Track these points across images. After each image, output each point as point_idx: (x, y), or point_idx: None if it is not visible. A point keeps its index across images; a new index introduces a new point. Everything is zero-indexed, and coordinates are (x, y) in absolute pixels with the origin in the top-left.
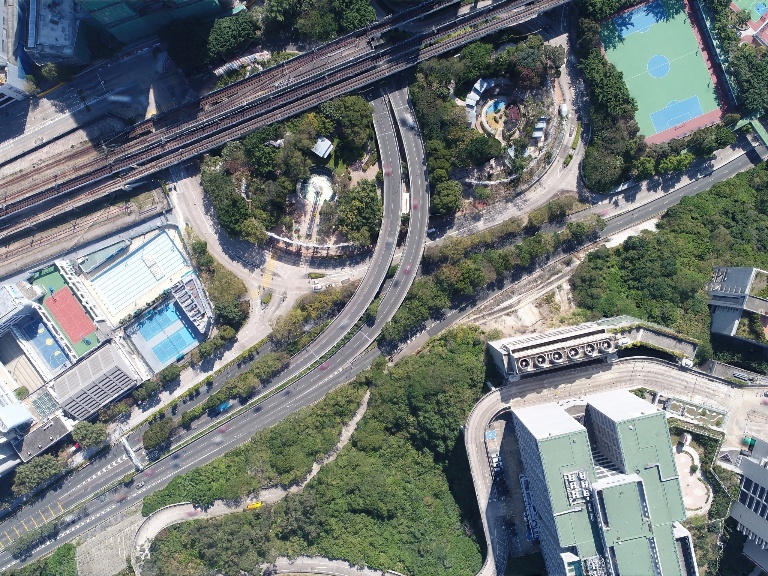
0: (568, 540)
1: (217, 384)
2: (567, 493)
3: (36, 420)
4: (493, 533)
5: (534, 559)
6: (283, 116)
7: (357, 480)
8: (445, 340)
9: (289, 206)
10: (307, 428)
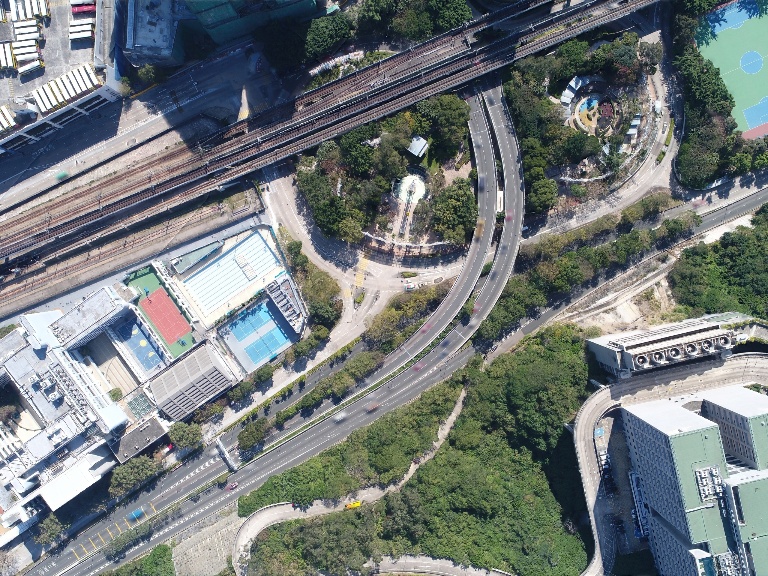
0: (700, 536)
1: (310, 384)
2: (699, 489)
3: (131, 421)
4: (601, 531)
5: (643, 556)
6: (378, 115)
7: (458, 479)
8: (541, 338)
9: (383, 205)
10: (404, 427)
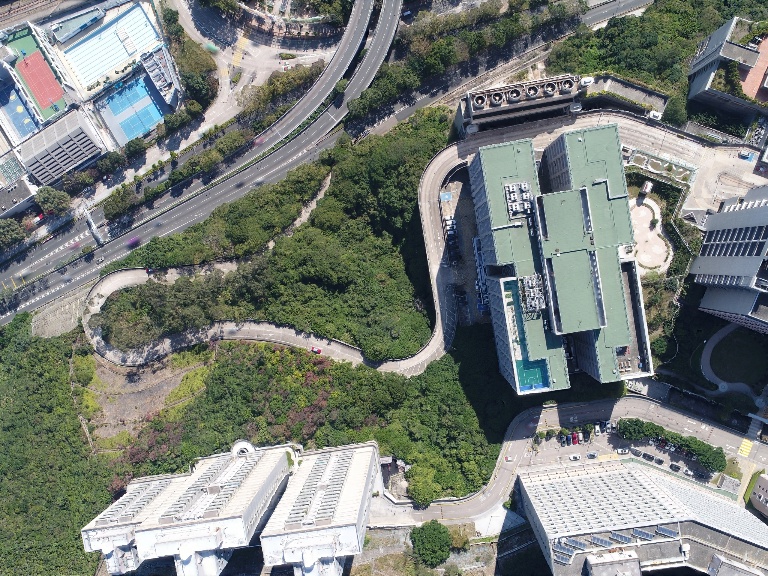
0: (506, 257)
1: (182, 164)
2: (507, 206)
3: (2, 185)
4: (443, 301)
5: (483, 327)
6: None
7: None
8: None
9: None
10: (266, 204)
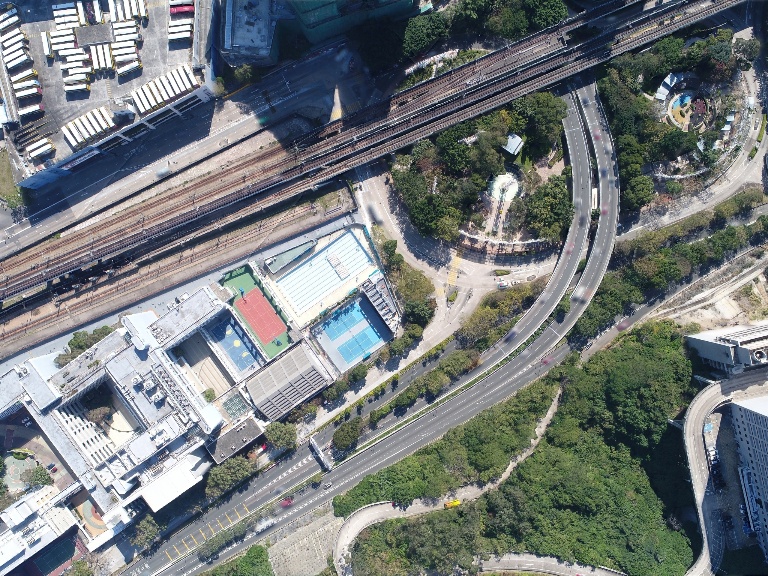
0: None
1: (402, 383)
2: None
3: (226, 422)
4: (709, 526)
5: (753, 552)
6: (474, 114)
7: (559, 476)
8: (636, 335)
9: (478, 203)
10: (501, 425)
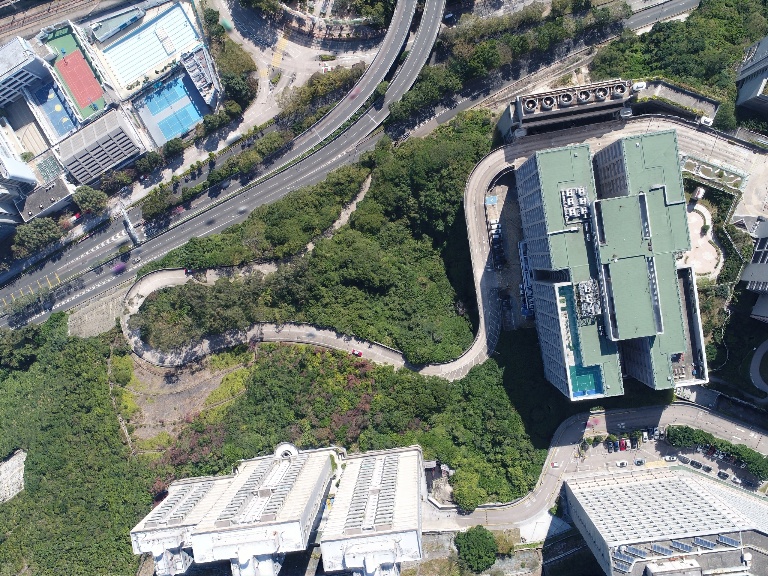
0: (561, 262)
1: (220, 164)
2: (563, 211)
3: (40, 183)
4: (486, 305)
5: (527, 332)
6: None
7: None
8: (454, 126)
9: None
10: (305, 206)
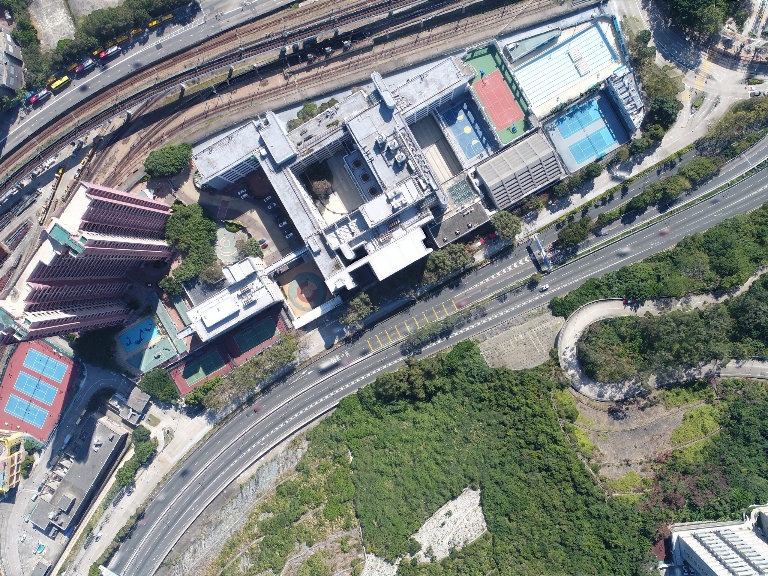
0: None
1: (633, 190)
2: None
3: (450, 208)
4: None
5: None
6: None
7: None
8: None
9: (741, 1)
10: (745, 235)
